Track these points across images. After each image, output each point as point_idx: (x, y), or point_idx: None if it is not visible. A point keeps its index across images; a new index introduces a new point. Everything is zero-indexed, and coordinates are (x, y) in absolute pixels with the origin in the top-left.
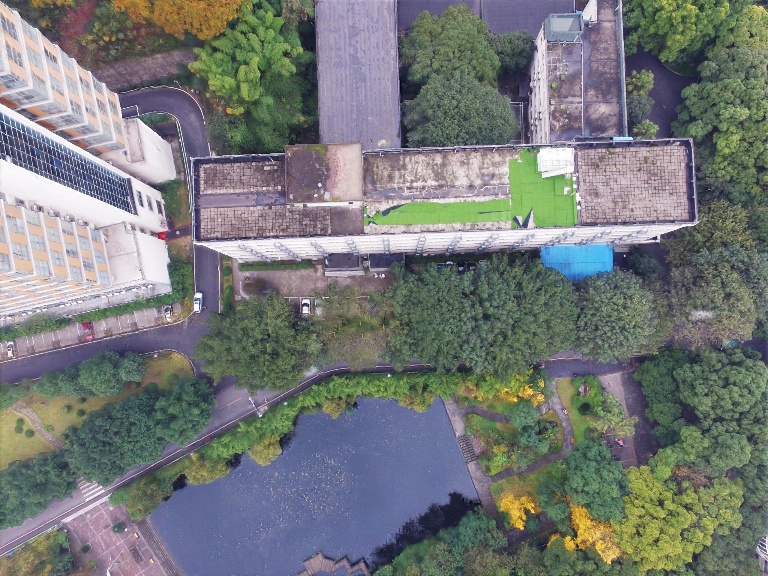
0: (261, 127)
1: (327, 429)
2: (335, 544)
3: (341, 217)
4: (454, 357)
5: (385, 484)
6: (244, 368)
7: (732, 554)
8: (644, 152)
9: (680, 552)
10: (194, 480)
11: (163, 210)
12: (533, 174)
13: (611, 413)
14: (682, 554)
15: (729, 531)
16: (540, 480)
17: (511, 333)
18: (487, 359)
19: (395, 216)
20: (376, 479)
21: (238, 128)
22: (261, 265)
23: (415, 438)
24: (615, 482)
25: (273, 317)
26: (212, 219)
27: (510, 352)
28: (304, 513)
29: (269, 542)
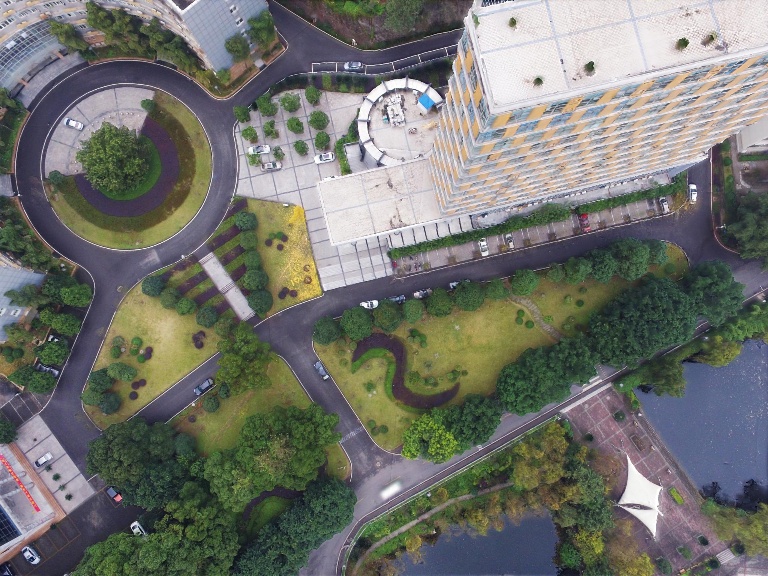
0: None
1: None
2: None
3: None
4: None
5: None
6: None
7: None
8: None
9: None
10: None
11: None
12: None
13: None
14: None
15: None
16: None
17: None
18: None
19: None
20: None
21: None
22: (760, 155)
23: None
24: None
25: None
26: None
27: None
28: None
29: (760, 429)
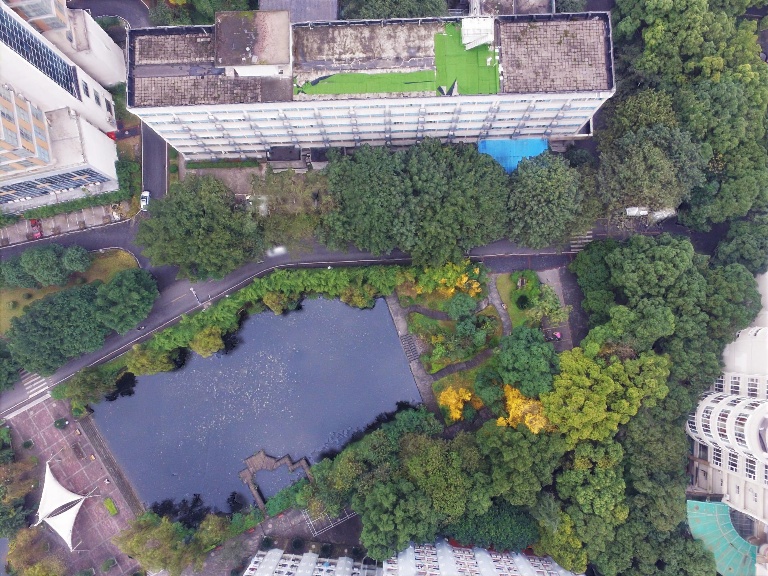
0: (206, 23)
1: (271, 328)
2: (277, 442)
3: (271, 87)
4: (387, 237)
5: (328, 383)
6: (180, 244)
7: (658, 425)
8: (564, 26)
9: (604, 417)
10: (134, 369)
11: (113, 111)
12: (457, 47)
13: (546, 302)
14: (608, 423)
15: (655, 403)
16: (478, 372)
17: (440, 207)
18: (417, 235)
19: (323, 86)
20: (319, 378)
21: (182, 22)
22: (207, 163)
23: (358, 337)
24: (544, 358)
25: (207, 190)
26: (146, 88)
27: (440, 227)
28: (247, 411)
29: (211, 440)
